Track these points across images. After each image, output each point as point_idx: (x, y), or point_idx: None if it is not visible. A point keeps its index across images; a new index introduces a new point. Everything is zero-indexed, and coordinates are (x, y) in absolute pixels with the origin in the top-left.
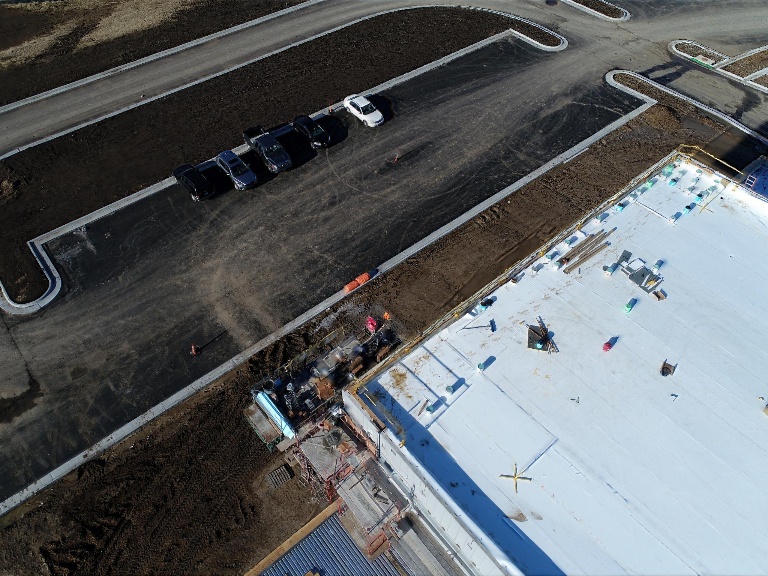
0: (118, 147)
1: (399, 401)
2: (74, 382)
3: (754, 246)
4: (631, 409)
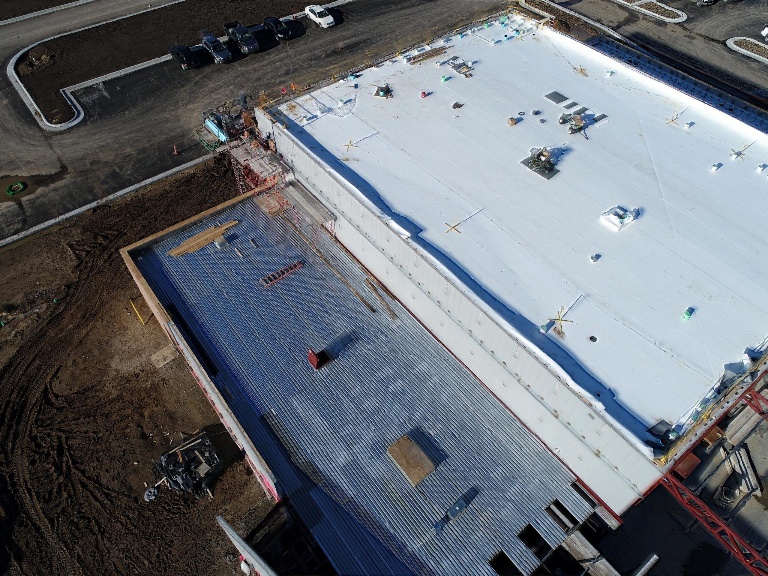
0: (129, 36)
1: (289, 116)
2: (91, 167)
3: (543, 57)
4: (428, 121)
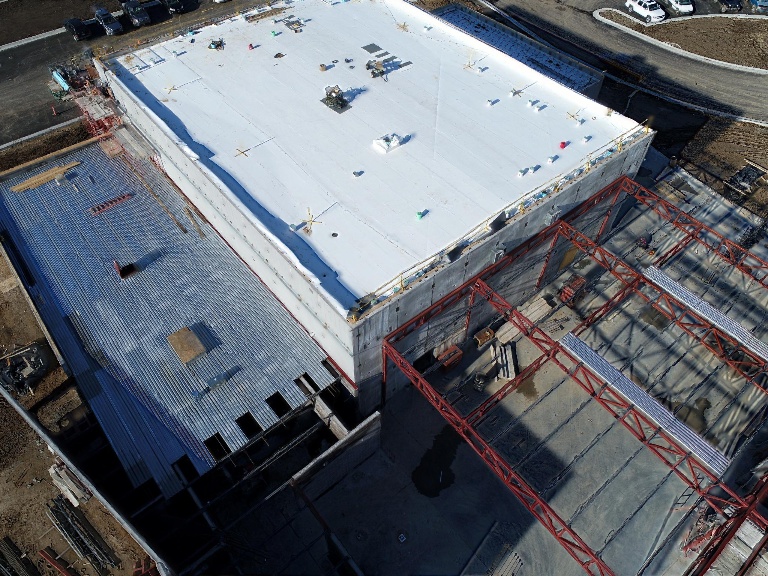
0: (28, 11)
1: (124, 66)
2: None
3: (373, 15)
4: (249, 68)
